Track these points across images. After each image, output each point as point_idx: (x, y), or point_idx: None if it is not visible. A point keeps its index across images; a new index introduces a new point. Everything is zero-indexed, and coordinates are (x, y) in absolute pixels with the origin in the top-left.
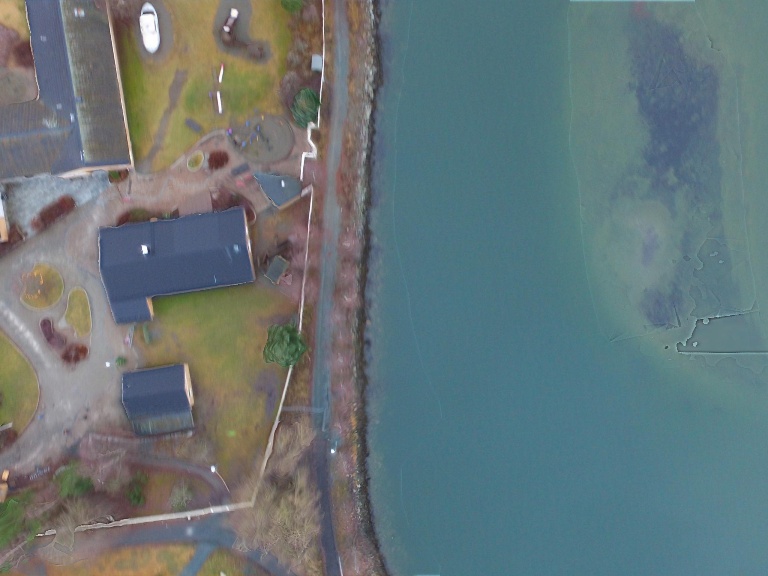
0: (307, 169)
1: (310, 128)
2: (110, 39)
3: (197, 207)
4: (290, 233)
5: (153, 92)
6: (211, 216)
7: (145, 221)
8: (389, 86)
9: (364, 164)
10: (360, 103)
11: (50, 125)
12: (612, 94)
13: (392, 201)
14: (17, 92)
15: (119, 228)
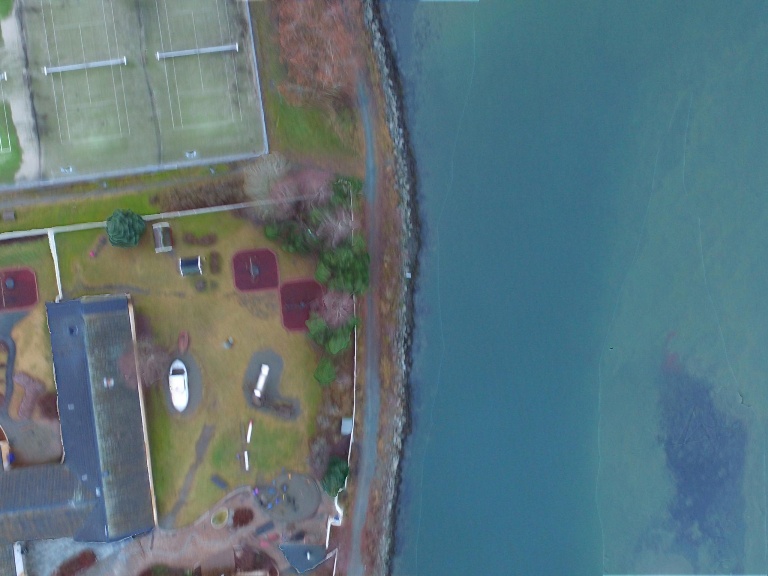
0: (333, 543)
1: None
2: (138, 401)
3: (220, 564)
4: None
5: (179, 446)
6: None
7: None
8: (417, 431)
9: (389, 515)
10: (388, 457)
11: (75, 498)
12: (640, 447)
13: (415, 545)
14: (41, 445)
15: None
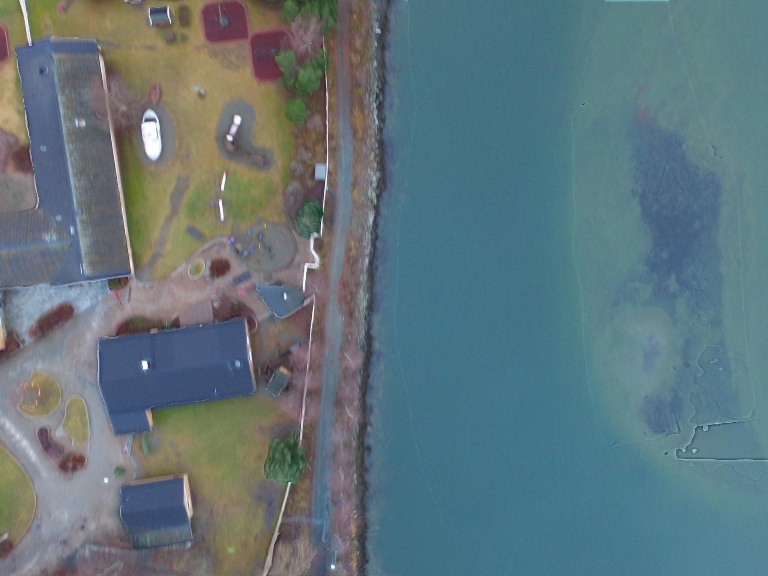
0: (310, 282)
1: (313, 238)
2: (111, 147)
3: (198, 315)
4: (292, 343)
5: (154, 198)
6: (212, 328)
7: (145, 331)
8: (392, 190)
9: (366, 270)
10: (363, 209)
11: (49, 237)
12: (615, 200)
13: (394, 305)
14: (15, 198)
15: (119, 339)
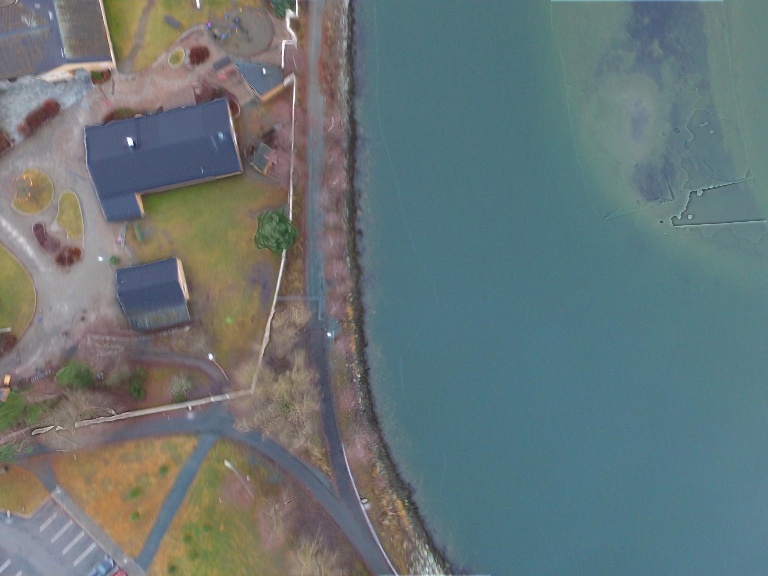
0: (287, 55)
1: (288, 16)
2: None
3: (181, 103)
4: (275, 123)
5: None
6: (195, 108)
7: (130, 119)
8: None
9: (345, 54)
10: None
11: (30, 24)
12: None
13: (376, 91)
14: None
15: (104, 125)
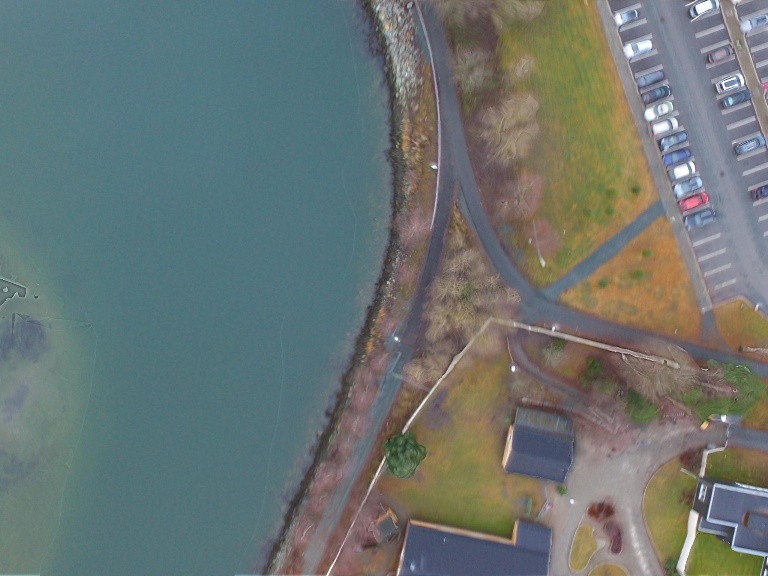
0: None
1: None
2: None
3: None
4: None
5: None
6: None
7: None
8: None
9: None
10: None
11: None
12: None
13: (254, 538)
14: None
15: None
